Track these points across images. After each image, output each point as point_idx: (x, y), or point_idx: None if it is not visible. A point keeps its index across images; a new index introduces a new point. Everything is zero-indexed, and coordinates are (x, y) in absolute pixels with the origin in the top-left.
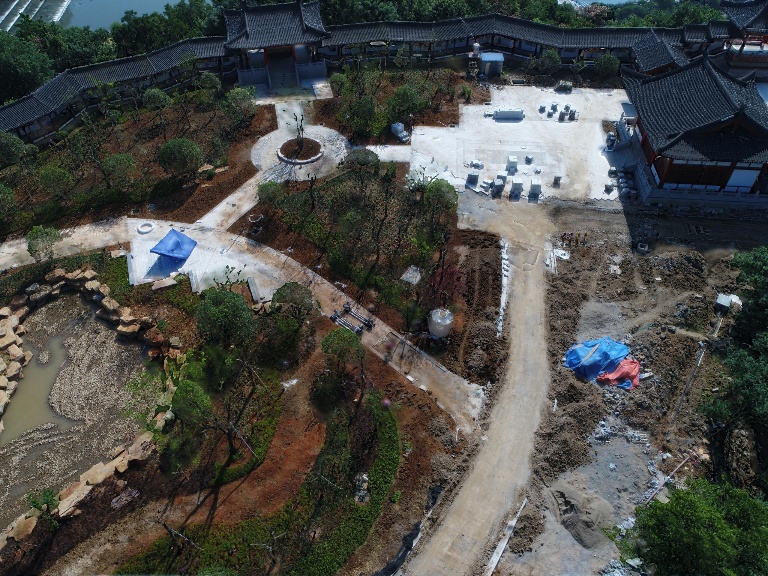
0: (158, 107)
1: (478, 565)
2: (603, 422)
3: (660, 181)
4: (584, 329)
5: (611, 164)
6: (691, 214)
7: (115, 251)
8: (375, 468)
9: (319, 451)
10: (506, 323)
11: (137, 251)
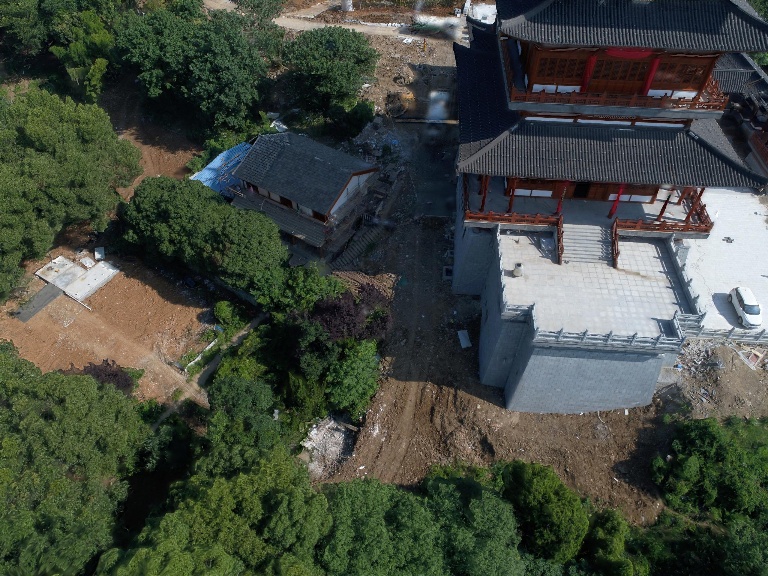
0: None
1: None
2: None
3: None
4: None
5: None
6: None
7: None
8: None
9: None
10: None
11: None
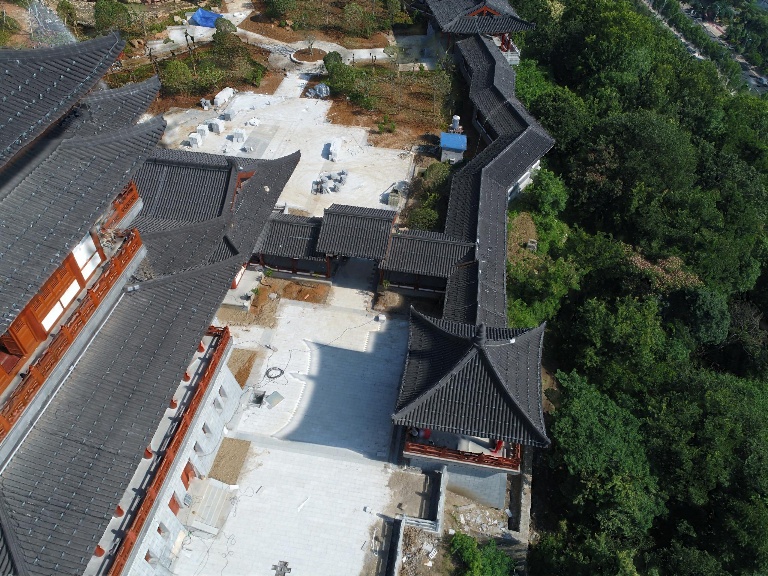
0: (385, 7)
1: None
2: None
3: None
4: None
5: None
6: None
7: (216, 7)
8: None
9: None
10: None
11: None
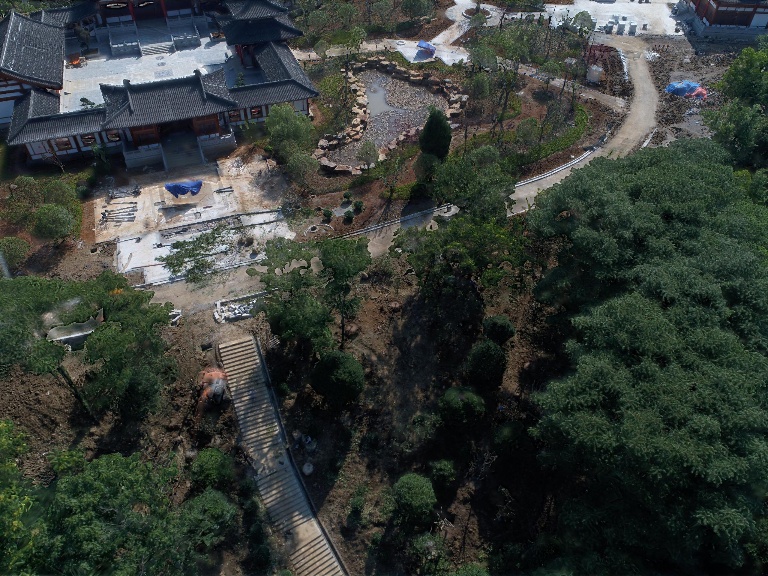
0: None
1: (638, 145)
2: (690, 109)
3: (710, 23)
4: (673, 81)
5: (676, 21)
6: (729, 41)
7: (391, 49)
8: (577, 118)
9: (546, 113)
10: (629, 78)
11: (402, 51)
